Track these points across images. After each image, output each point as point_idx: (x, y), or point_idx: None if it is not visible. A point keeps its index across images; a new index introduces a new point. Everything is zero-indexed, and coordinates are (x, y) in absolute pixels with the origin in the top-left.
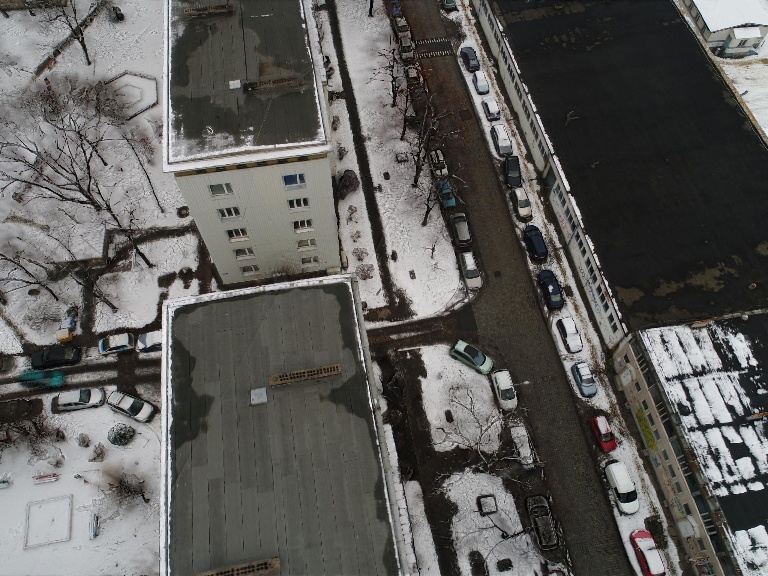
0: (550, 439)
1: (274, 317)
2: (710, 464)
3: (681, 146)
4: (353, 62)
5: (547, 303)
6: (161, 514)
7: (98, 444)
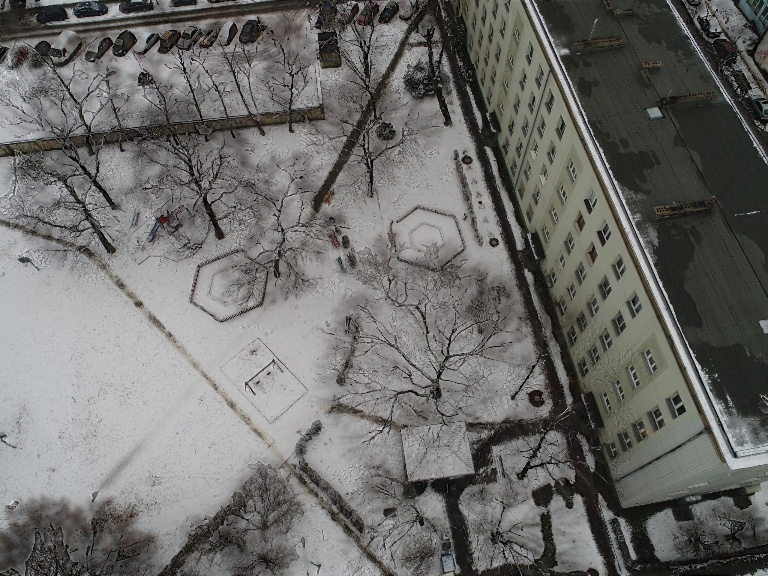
0: None
1: None
2: None
3: None
4: None
5: None
6: None
7: None
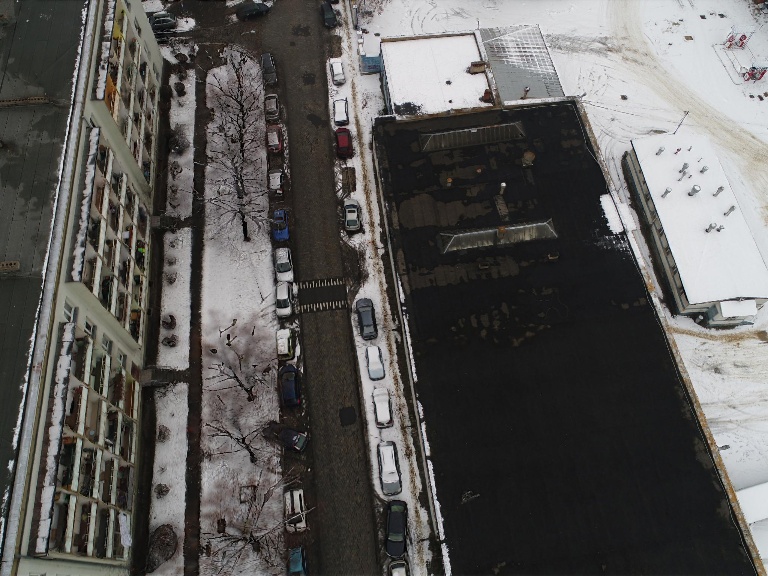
0: None
1: None
2: None
3: (626, 542)
4: (210, 317)
5: None
6: None
7: None
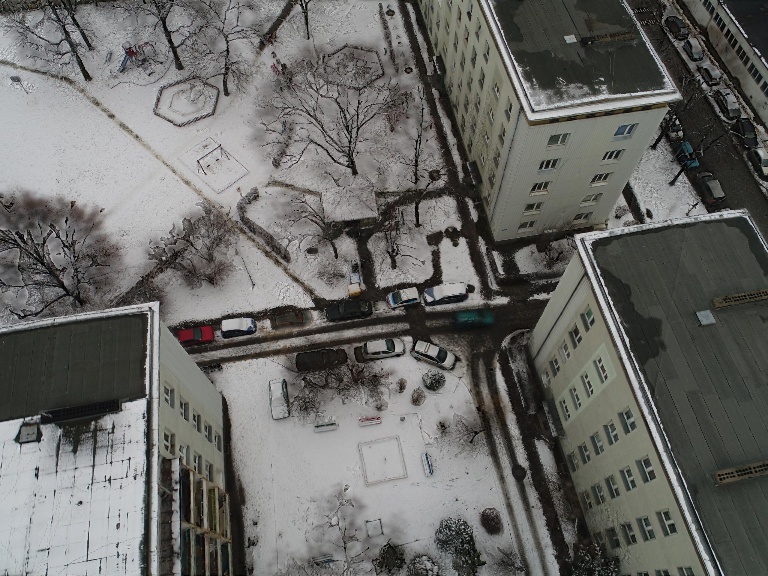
0: None
1: (690, 248)
2: None
3: None
4: None
5: None
6: (649, 423)
7: (416, 389)
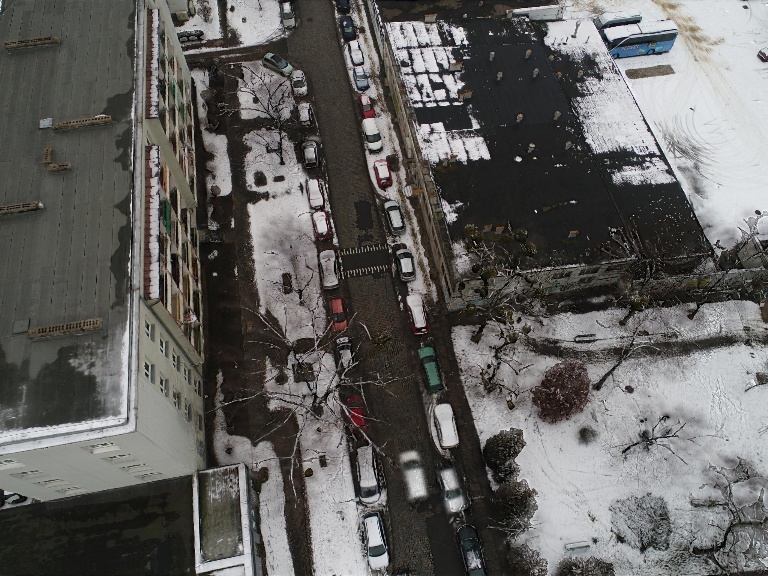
0: (328, 113)
1: None
2: (414, 91)
3: None
4: None
5: (343, 35)
6: None
7: None
